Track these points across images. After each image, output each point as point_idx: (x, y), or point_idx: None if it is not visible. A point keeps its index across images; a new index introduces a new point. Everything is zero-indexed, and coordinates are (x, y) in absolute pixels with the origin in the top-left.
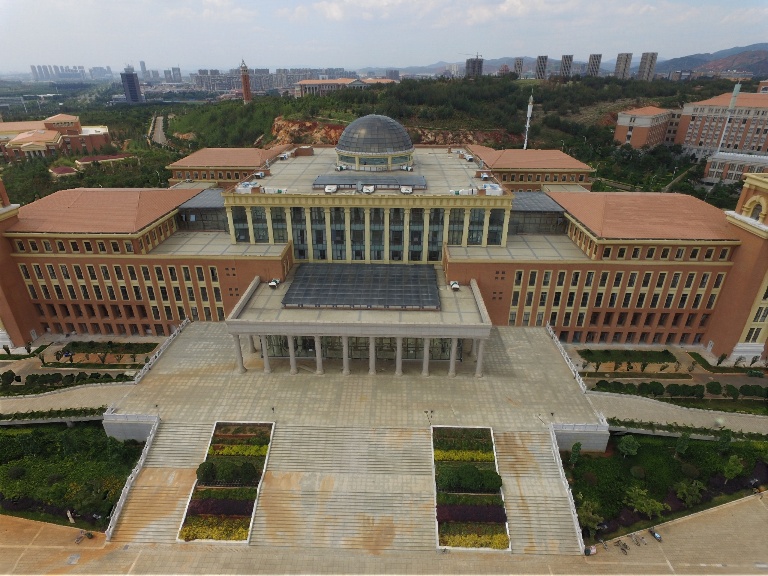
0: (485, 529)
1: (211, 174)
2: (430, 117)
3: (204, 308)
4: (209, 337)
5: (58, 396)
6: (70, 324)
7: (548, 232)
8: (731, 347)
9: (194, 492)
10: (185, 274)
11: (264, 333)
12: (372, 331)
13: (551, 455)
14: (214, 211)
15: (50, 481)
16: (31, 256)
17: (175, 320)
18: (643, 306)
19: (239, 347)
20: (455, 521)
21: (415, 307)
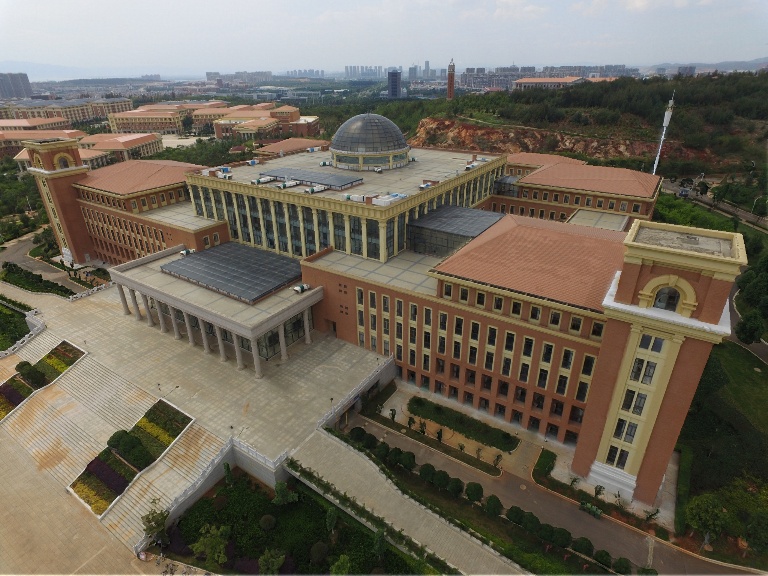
0: (104, 492)
1: None
2: (583, 121)
3: None
4: None
5: (38, 296)
6: None
7: None
8: (587, 462)
9: (10, 378)
10: (149, 232)
11: (127, 286)
12: (179, 305)
13: None
14: None
15: None
16: (84, 202)
17: None
18: (493, 369)
19: (122, 293)
20: None
21: (235, 296)
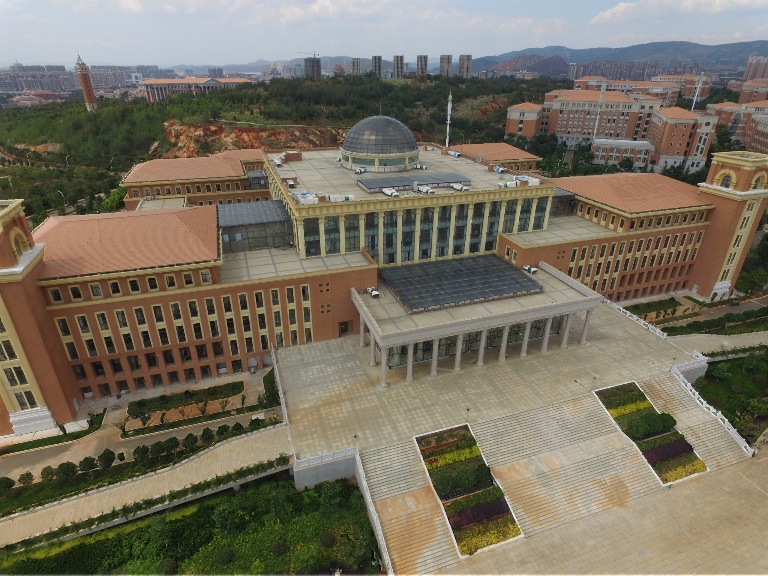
0: (683, 460)
1: (176, 189)
2: (338, 117)
3: (290, 332)
4: (313, 361)
5: (201, 461)
6: (118, 382)
7: (562, 214)
8: (712, 287)
9: (446, 508)
10: (272, 298)
11: (416, 341)
12: (511, 319)
13: (684, 391)
14: (262, 227)
15: (277, 550)
16: (77, 306)
17: (257, 351)
18: (654, 265)
19: None
20: (660, 461)
21: (524, 292)
